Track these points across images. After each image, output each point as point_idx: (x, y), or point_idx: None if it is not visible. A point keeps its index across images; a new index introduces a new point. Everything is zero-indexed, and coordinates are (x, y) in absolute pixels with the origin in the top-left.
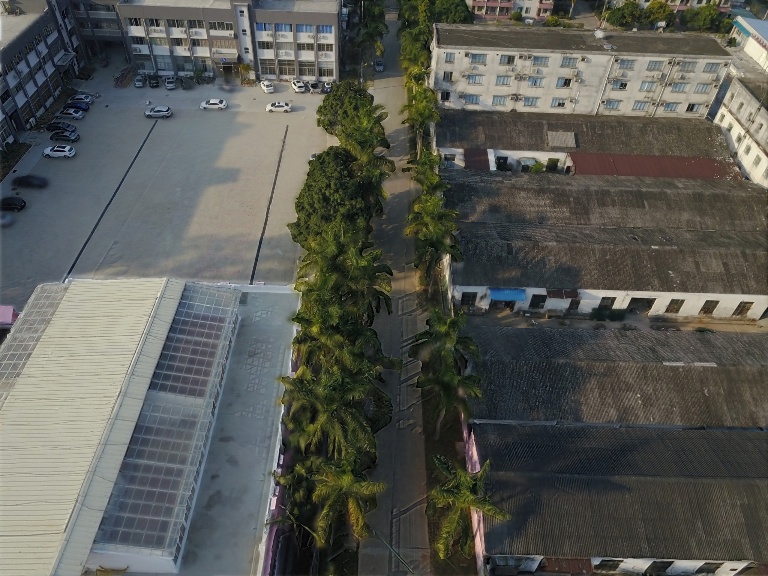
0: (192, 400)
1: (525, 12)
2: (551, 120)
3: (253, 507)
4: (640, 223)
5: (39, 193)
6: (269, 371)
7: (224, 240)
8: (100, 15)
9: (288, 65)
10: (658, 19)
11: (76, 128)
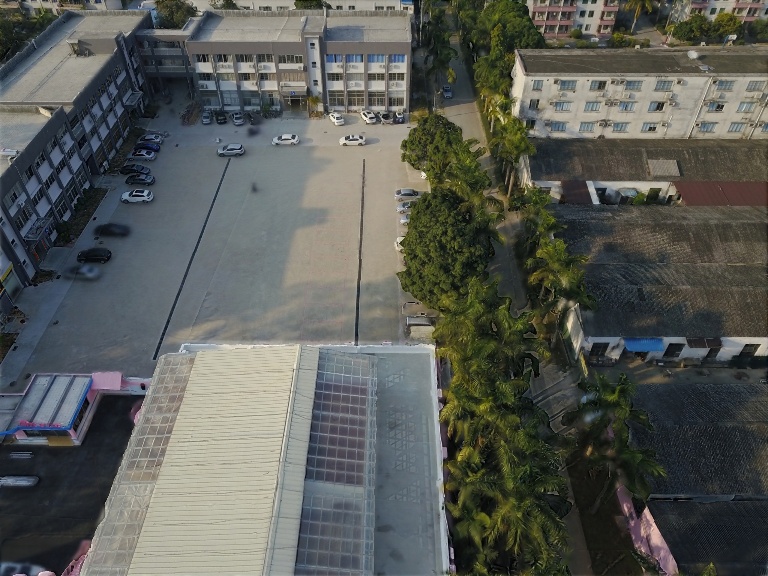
0: (352, 489)
1: (585, 29)
2: (649, 147)
3: None
4: None
5: (123, 242)
6: (415, 446)
7: (320, 287)
8: (165, 52)
9: (357, 96)
10: (728, 32)
11: (150, 170)
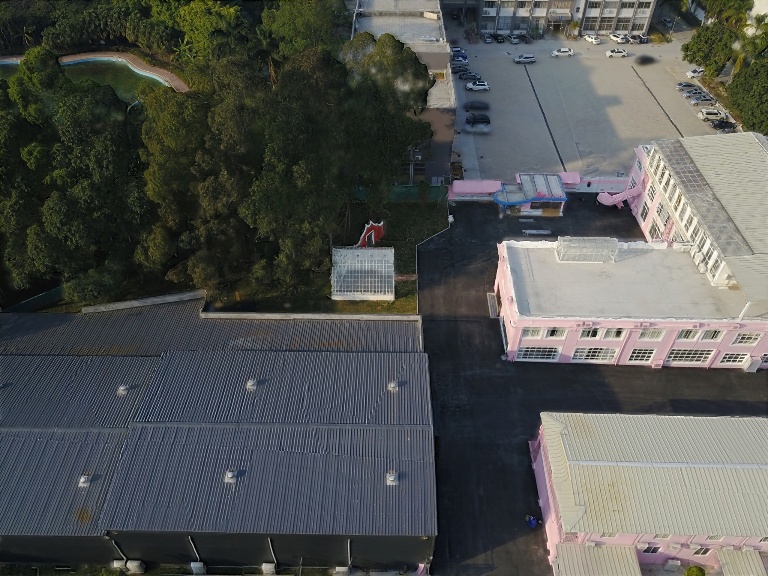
0: None
1: None
2: None
3: None
4: None
5: (488, 113)
6: None
7: None
8: None
9: (607, 22)
10: None
11: (471, 71)
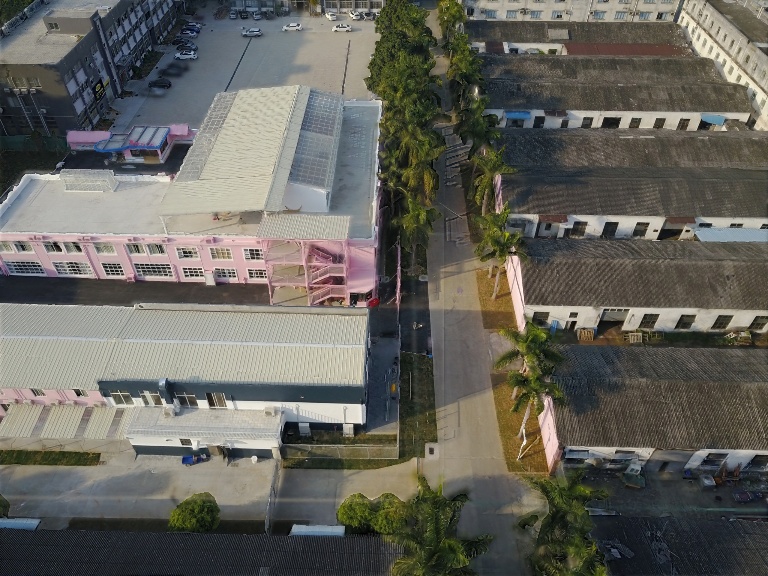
0: (326, 136)
1: None
2: (551, 22)
3: (366, 190)
4: (613, 79)
5: (178, 79)
6: (365, 139)
7: None
8: None
9: None
10: None
11: (193, 43)
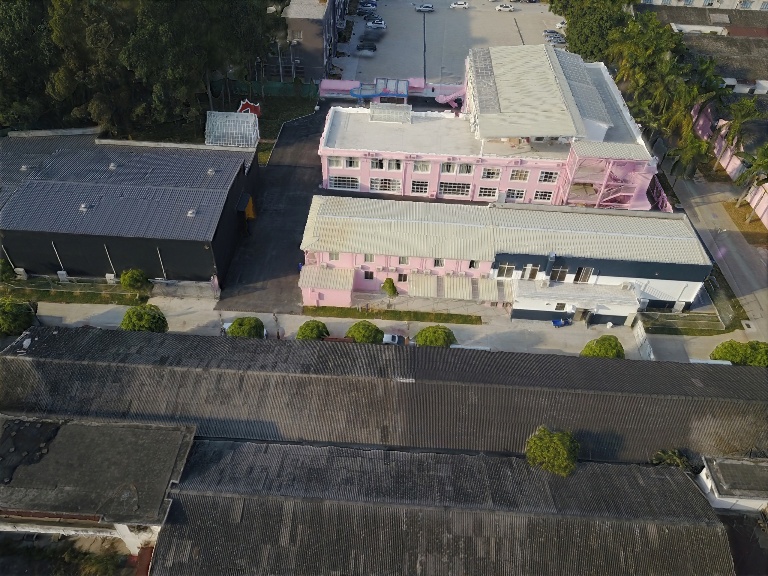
0: (586, 85)
1: None
2: (710, 8)
3: (626, 131)
4: None
5: (378, 44)
6: (603, 93)
7: None
8: None
9: None
10: None
11: None
